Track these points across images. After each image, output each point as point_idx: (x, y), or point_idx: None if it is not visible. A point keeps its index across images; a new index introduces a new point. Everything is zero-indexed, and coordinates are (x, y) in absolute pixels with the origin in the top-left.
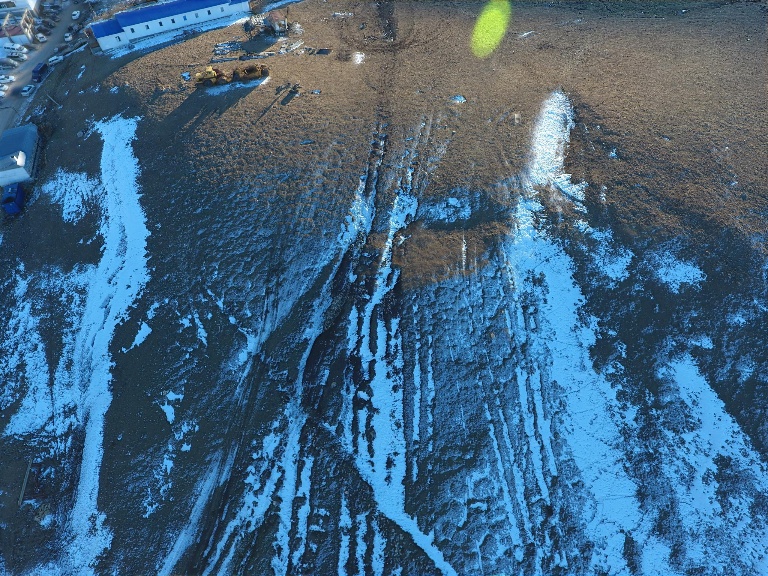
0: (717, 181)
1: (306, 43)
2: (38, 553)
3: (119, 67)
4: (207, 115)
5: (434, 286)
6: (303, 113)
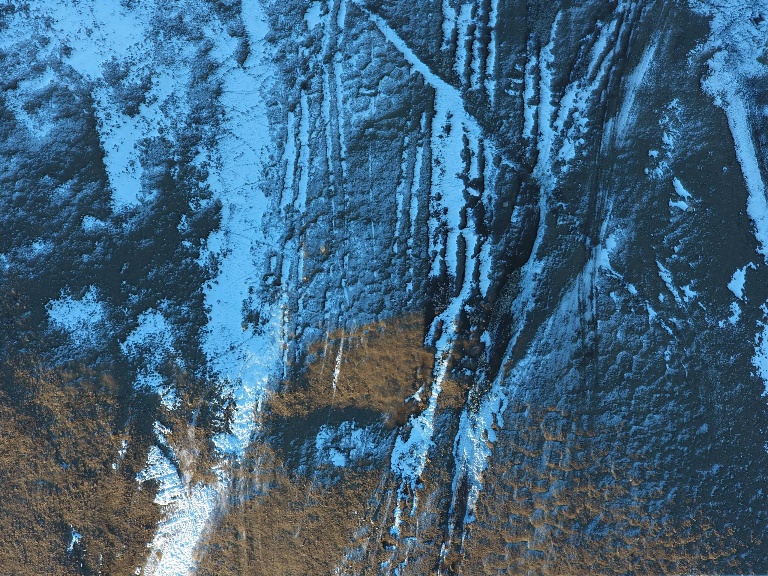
0: None
1: None
2: (764, 86)
3: None
4: None
5: (384, 315)
6: None
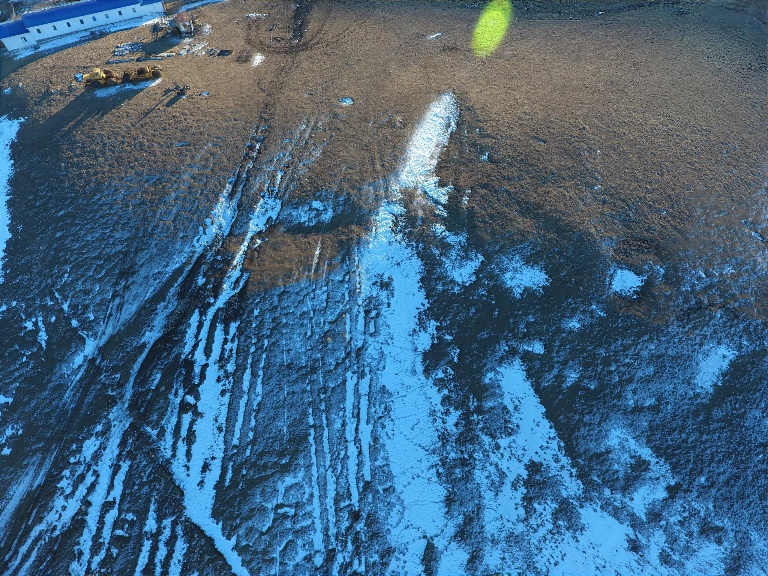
0: (581, 185)
1: (210, 44)
2: None
3: (18, 68)
4: (89, 117)
5: (279, 290)
6: (185, 115)
